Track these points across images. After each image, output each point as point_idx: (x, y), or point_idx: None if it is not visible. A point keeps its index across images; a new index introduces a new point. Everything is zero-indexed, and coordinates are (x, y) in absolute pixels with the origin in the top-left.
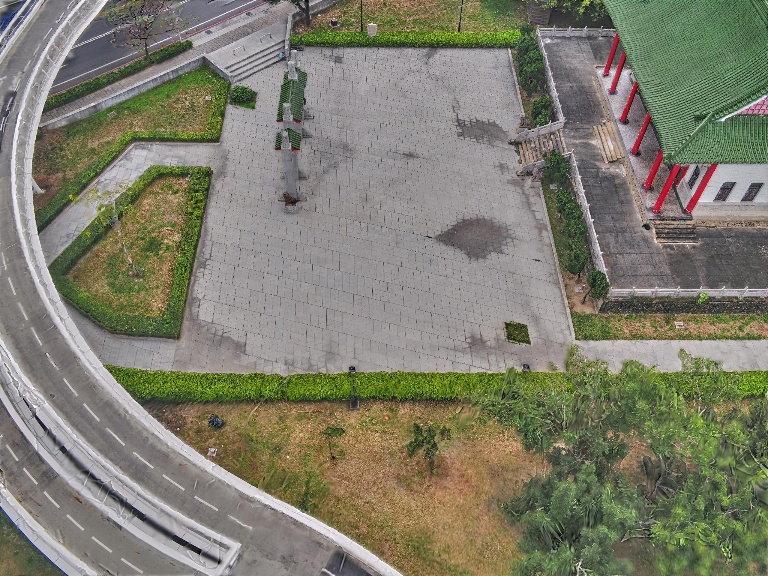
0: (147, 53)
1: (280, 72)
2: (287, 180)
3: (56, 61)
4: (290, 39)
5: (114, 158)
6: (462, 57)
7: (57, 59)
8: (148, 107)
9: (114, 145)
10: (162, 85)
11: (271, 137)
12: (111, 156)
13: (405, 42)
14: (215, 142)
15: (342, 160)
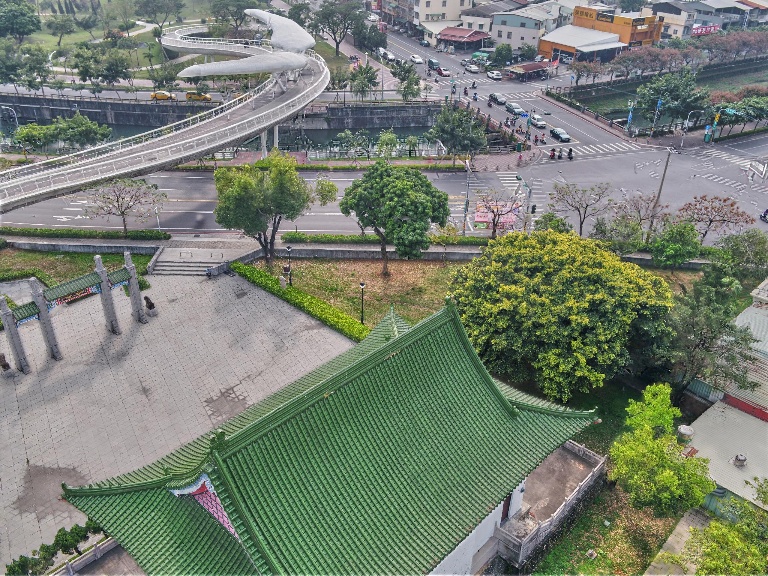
0: (125, 228)
1: (190, 282)
2: (10, 344)
3: (15, 197)
4: (231, 263)
5: (5, 280)
6: (332, 343)
7: (18, 196)
8: (83, 262)
9: (16, 272)
10: (115, 254)
11: (98, 320)
12: (1, 277)
13: (303, 307)
14: (67, 303)
15: (101, 363)
